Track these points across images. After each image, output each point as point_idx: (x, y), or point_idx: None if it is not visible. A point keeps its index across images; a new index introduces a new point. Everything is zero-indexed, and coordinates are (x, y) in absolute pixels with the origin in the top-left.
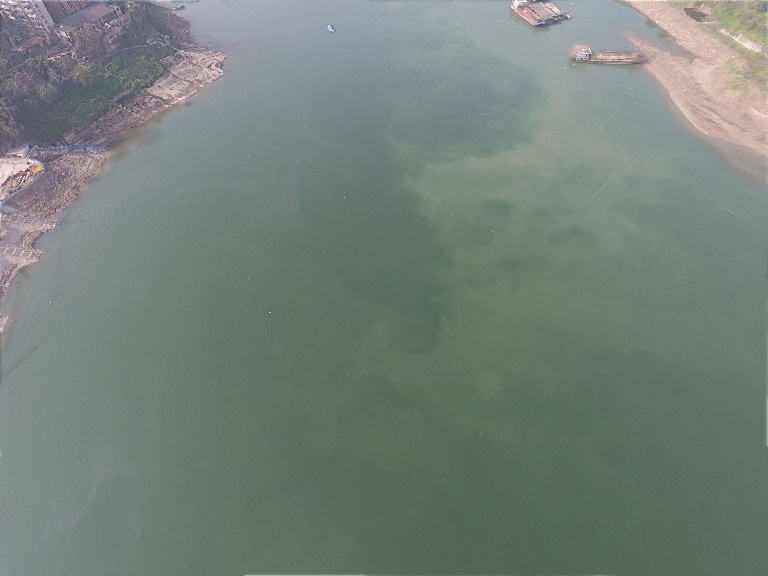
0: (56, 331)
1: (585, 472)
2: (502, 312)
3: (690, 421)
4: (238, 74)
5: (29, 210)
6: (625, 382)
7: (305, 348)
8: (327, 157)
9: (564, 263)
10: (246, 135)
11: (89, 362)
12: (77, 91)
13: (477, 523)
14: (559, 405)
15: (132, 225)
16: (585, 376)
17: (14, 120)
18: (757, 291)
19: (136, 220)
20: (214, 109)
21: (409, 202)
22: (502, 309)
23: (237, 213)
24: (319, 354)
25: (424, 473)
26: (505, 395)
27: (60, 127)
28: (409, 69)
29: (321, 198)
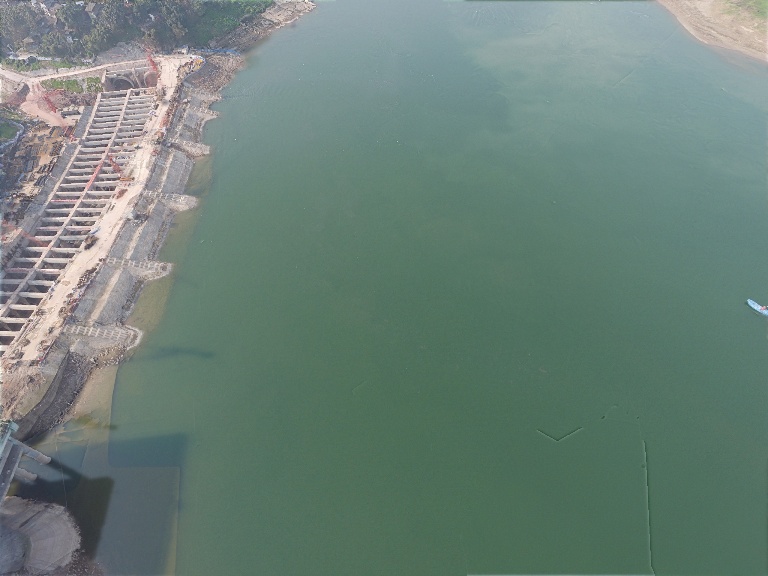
0: (247, 153)
1: (626, 218)
2: (561, 142)
3: (695, 194)
4: (327, 7)
5: (200, 87)
6: (650, 178)
7: (427, 159)
8: (414, 58)
9: (602, 119)
10: (347, 45)
11: (277, 168)
12: (214, 11)
13: (558, 240)
14: (606, 188)
15: (279, 97)
16: (622, 175)
17: (181, 24)
18: (742, 131)
19: (280, 95)
20: (316, 29)
21: (484, 82)
22: (561, 140)
23: (355, 90)
24: (438, 161)
25: (520, 218)
26: (569, 183)
27: (206, 36)
28: (465, 5)
29: (416, 82)
